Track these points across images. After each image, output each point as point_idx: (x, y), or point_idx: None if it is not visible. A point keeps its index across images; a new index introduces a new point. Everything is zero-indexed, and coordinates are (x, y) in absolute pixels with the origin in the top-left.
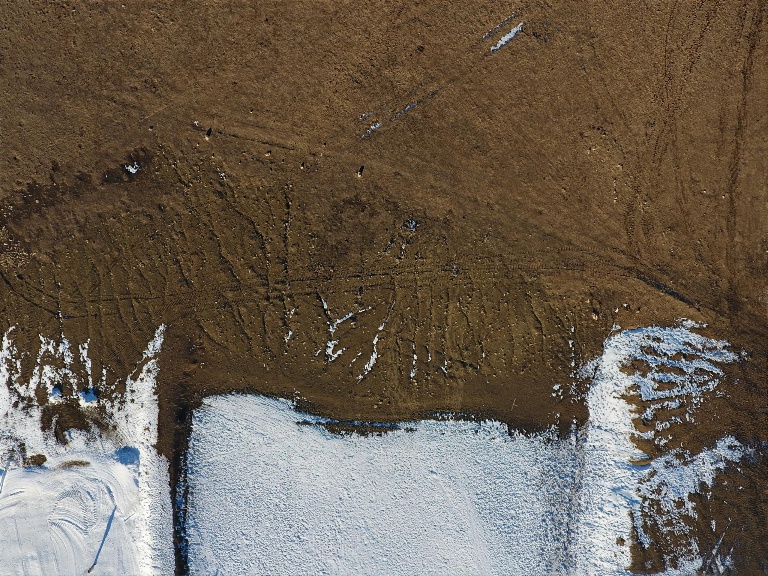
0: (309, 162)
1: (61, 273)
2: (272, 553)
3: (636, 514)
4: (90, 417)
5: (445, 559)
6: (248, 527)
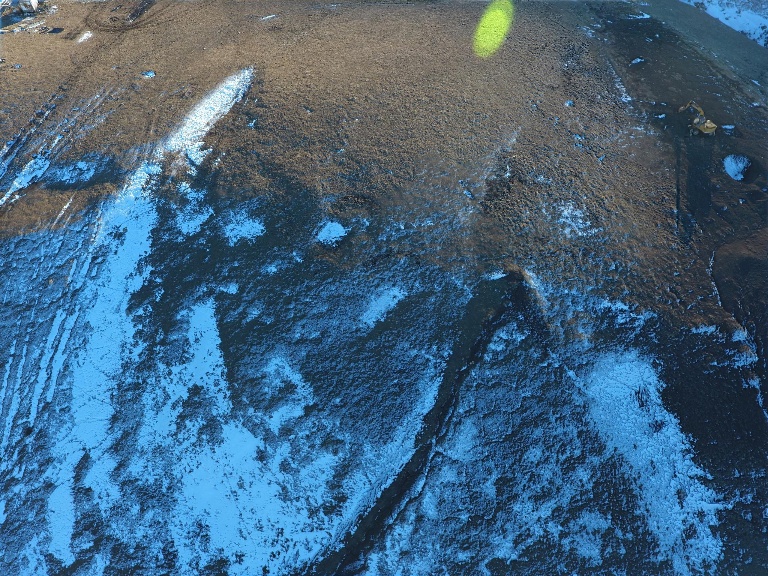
0: (365, 2)
1: None
2: None
3: None
4: None
5: None
6: None
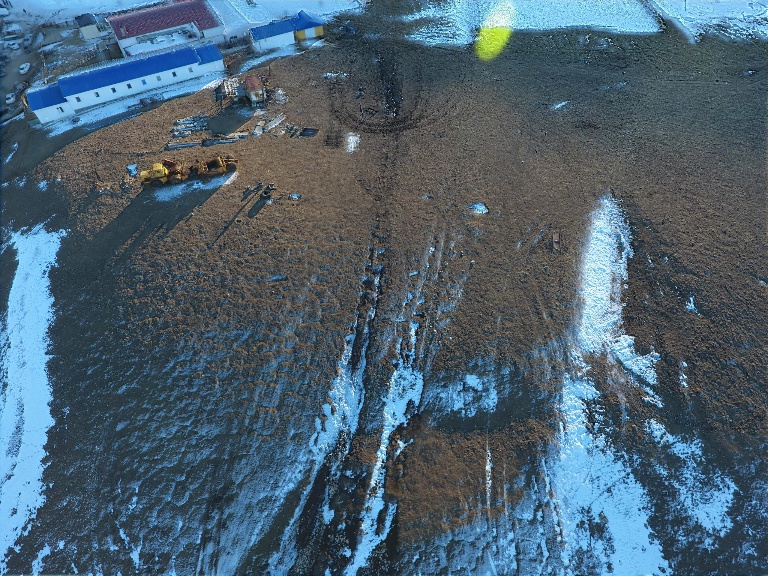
0: None
1: (763, 49)
2: (608, 3)
3: (453, 6)
4: (715, 26)
5: (531, 3)
6: (623, 7)
